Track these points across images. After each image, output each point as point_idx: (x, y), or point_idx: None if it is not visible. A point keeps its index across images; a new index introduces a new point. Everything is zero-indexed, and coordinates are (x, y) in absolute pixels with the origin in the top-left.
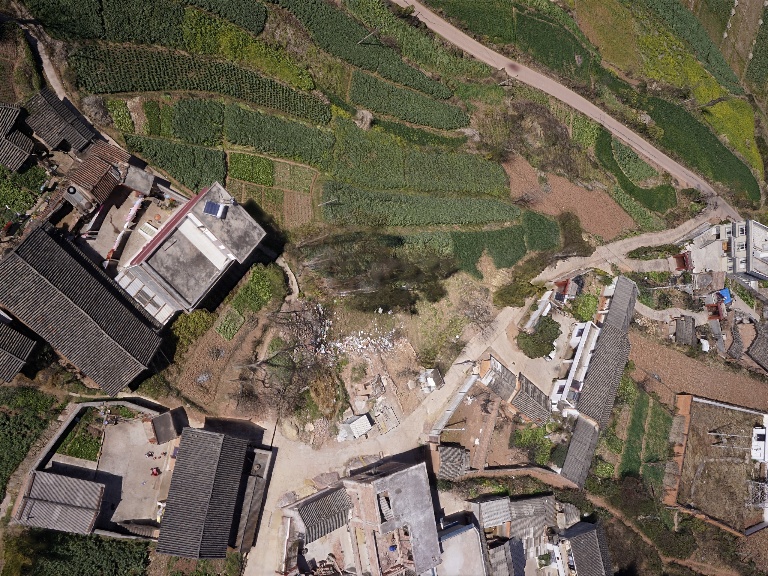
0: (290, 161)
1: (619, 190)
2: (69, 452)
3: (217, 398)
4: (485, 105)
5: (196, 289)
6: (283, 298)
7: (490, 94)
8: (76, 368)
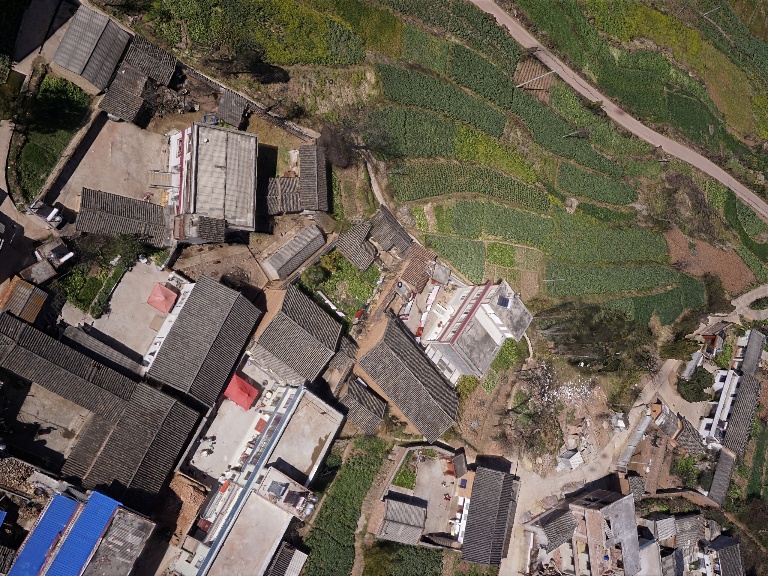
0: (524, 245)
1: (743, 248)
2: (398, 483)
3: (482, 439)
4: (647, 180)
5: (484, 361)
6: None
7: (651, 170)
8: (400, 419)
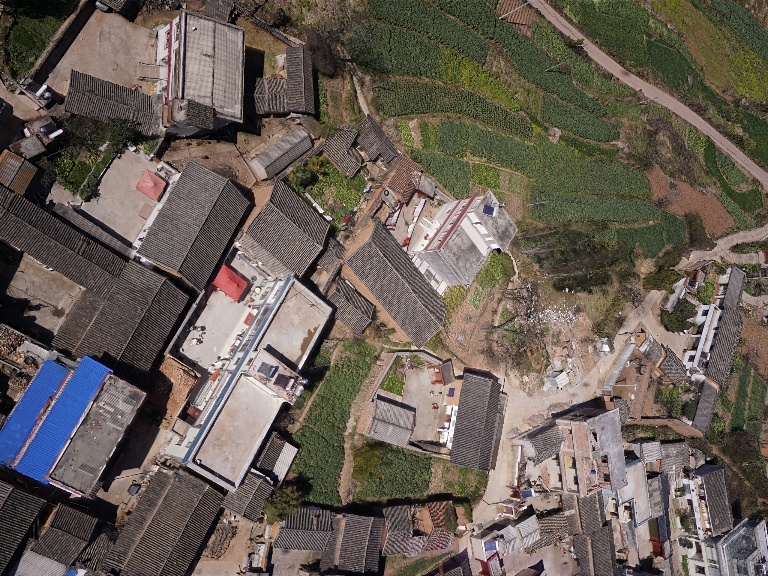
0: (509, 169)
1: (723, 194)
2: (386, 388)
3: (470, 353)
4: (628, 121)
5: (470, 270)
6: (510, 278)
7: (631, 111)
8: (387, 326)
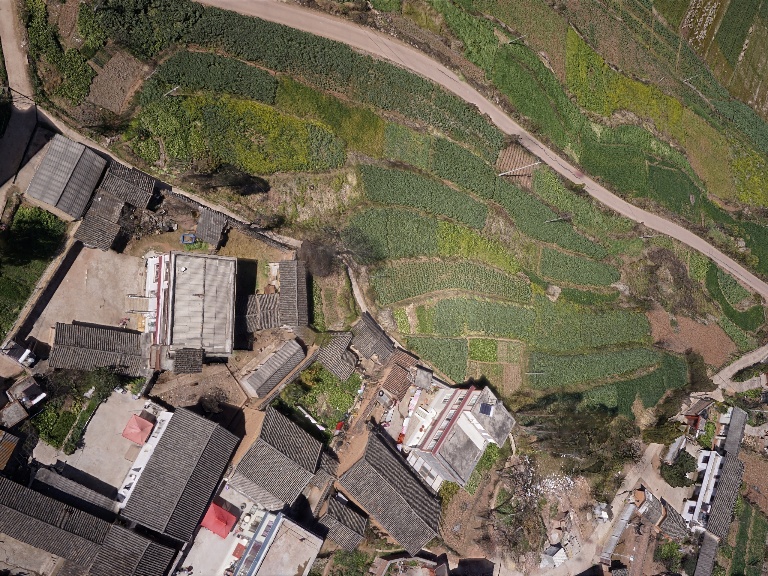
0: (507, 339)
1: (725, 318)
2: None
3: (465, 543)
4: (629, 258)
5: (466, 468)
6: (507, 457)
7: (633, 247)
8: (381, 530)
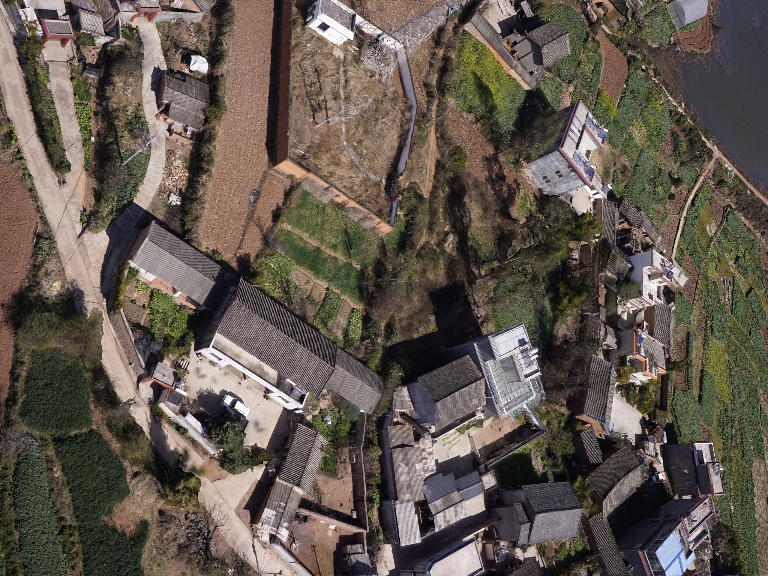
0: None
1: None
2: None
3: None
4: None
5: None
6: None
7: None
8: None
